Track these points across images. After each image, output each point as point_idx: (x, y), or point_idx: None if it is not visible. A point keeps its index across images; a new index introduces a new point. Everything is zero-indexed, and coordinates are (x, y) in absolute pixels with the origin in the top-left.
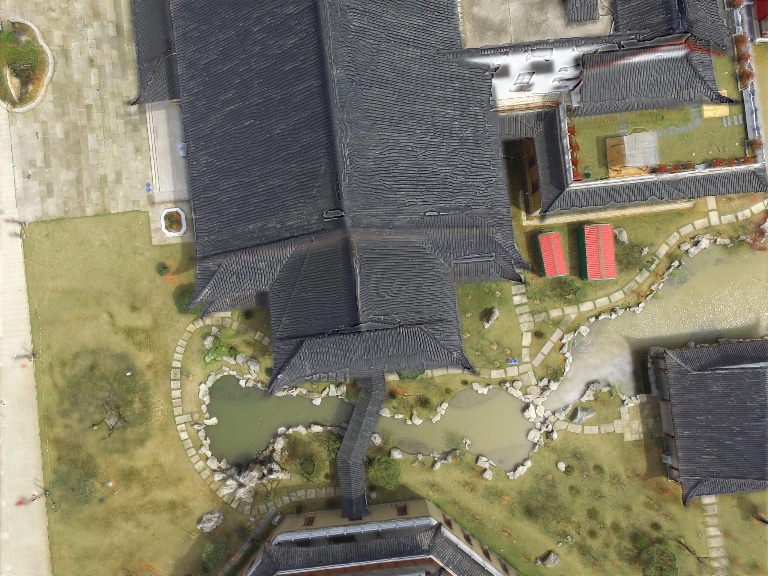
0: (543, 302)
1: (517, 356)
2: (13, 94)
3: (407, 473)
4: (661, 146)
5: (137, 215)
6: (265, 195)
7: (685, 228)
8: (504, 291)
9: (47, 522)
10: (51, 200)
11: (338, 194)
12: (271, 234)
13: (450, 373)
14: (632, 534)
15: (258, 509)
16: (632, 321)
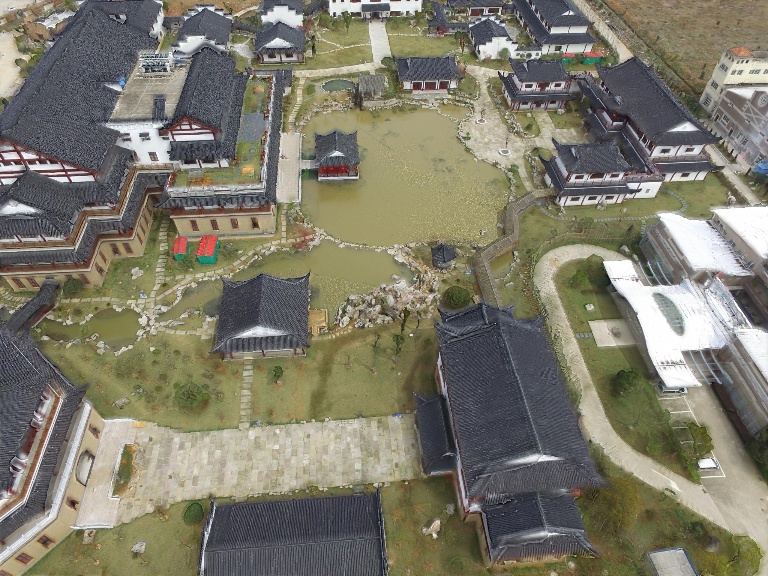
0: (174, 272)
1: (148, 294)
2: None
3: (48, 350)
4: None
5: None
6: None
7: (267, 244)
8: (152, 265)
9: None
10: None
11: None
12: None
13: (102, 300)
14: None
15: None
16: None
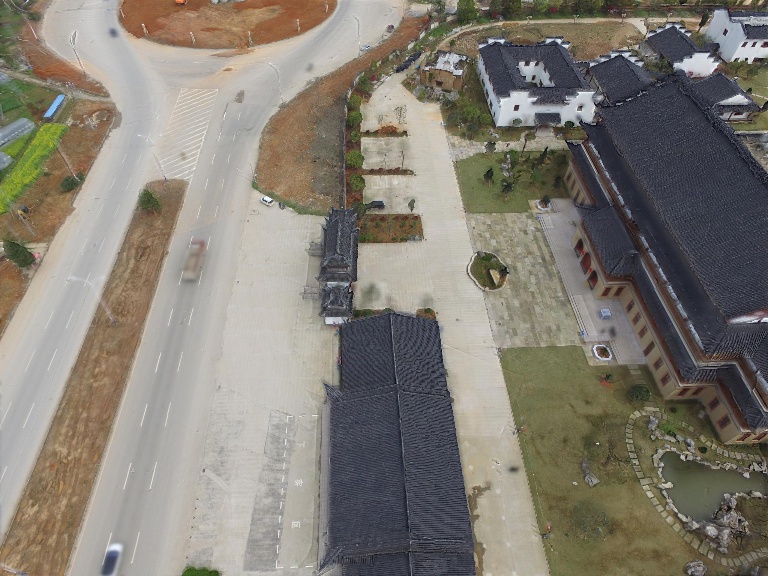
0: None
1: None
2: (495, 281)
3: None
4: None
5: (575, 348)
6: None
7: None
8: None
9: (548, 564)
10: (516, 337)
11: None
12: None
13: None
14: None
15: (733, 562)
16: None
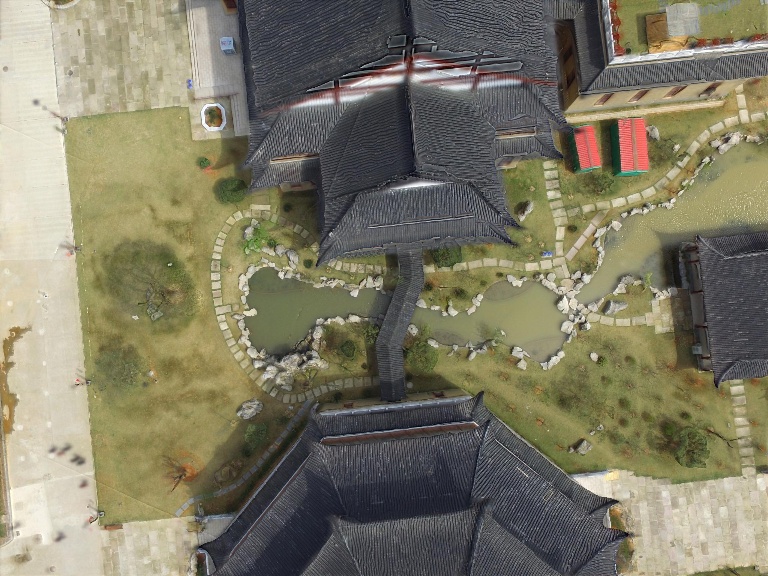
0: (576, 198)
1: (551, 250)
2: None
3: (443, 363)
4: (700, 24)
5: (177, 111)
6: (326, 33)
7: (716, 126)
8: (538, 186)
9: (89, 411)
10: (92, 96)
11: (406, 10)
12: (332, 70)
13: (485, 266)
14: (663, 424)
15: (297, 398)
16: (663, 217)
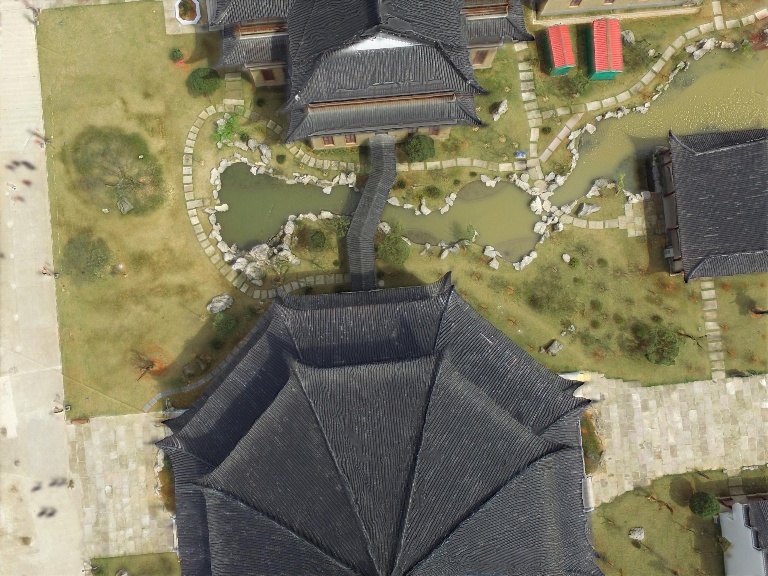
0: (551, 100)
1: (525, 151)
2: None
3: (415, 262)
4: None
5: (151, 4)
6: None
7: (691, 32)
8: (513, 87)
9: (56, 305)
10: None
11: None
12: None
13: (459, 165)
14: (634, 326)
15: (267, 294)
16: (638, 121)
